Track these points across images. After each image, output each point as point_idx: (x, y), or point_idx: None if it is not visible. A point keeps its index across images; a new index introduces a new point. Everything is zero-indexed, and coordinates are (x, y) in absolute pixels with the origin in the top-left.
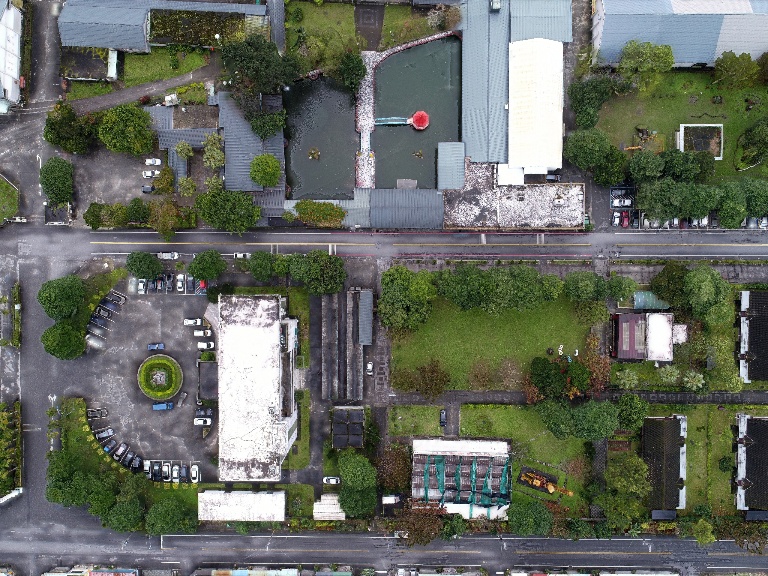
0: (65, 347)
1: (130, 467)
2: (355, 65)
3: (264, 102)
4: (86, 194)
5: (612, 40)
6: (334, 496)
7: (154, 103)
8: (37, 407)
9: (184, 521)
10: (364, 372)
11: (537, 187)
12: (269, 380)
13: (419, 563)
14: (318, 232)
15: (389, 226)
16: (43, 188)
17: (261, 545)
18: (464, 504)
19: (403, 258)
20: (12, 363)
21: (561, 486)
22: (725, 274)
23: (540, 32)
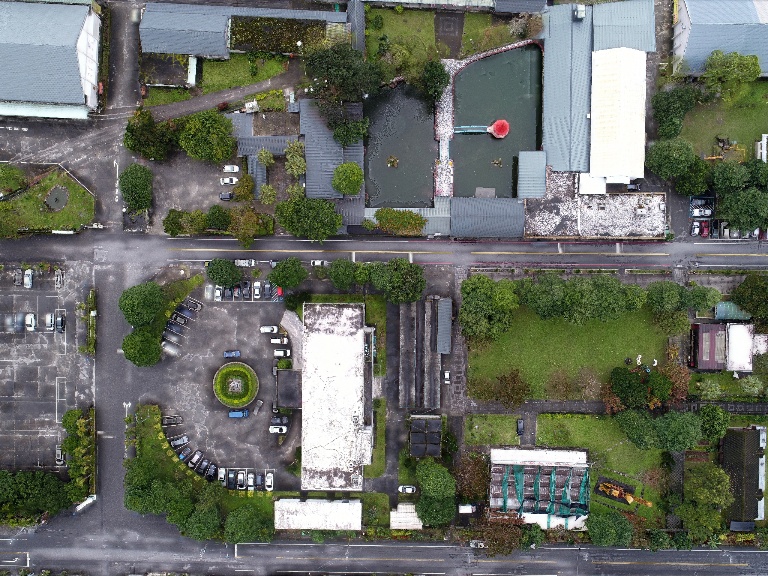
0: (145, 354)
1: (204, 475)
2: (439, 73)
3: (345, 110)
4: (163, 200)
5: (697, 50)
6: (411, 505)
7: (232, 110)
8: (112, 414)
9: (263, 530)
10: (441, 381)
11: (618, 196)
12: (352, 389)
13: (494, 573)
14: (396, 240)
15: (469, 235)
16: (123, 194)
17: (336, 554)
18: (542, 514)
19: (481, 267)
20: (87, 370)
21: (638, 496)
22: None
23: (623, 41)
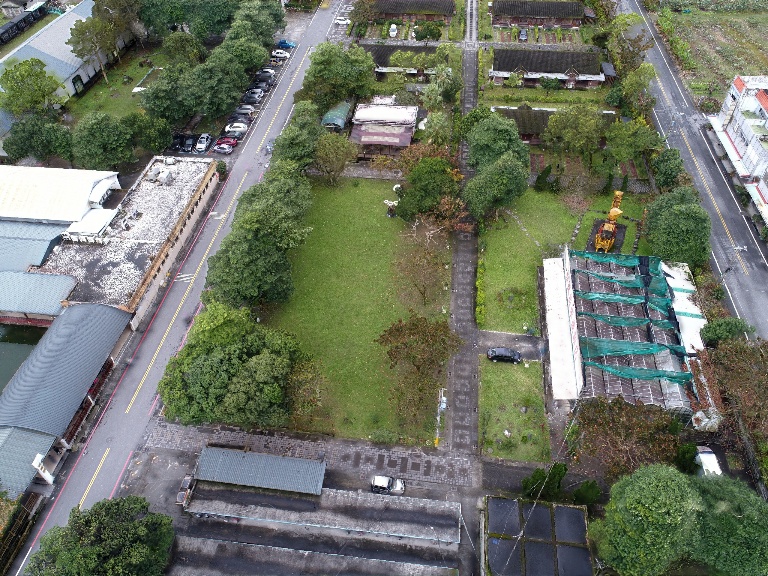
0: None
1: None
2: None
3: None
4: None
5: None
6: None
7: None
8: None
9: None
10: None
11: (131, 200)
12: None
13: None
14: None
15: (76, 400)
16: None
17: None
18: None
19: None
20: None
21: None
22: None
23: None
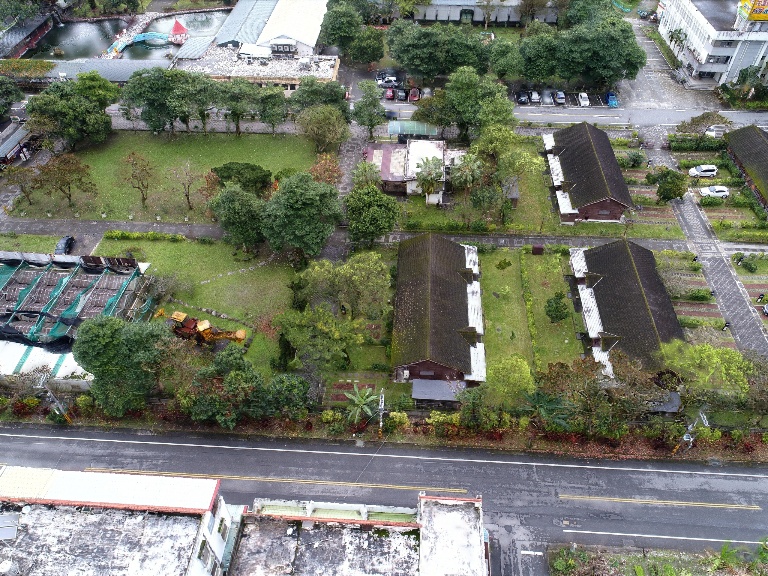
0: None
1: None
2: None
3: None
4: None
5: None
6: None
7: None
8: None
9: None
10: None
11: (285, 60)
12: None
13: None
14: None
15: None
16: None
17: None
18: (16, 345)
19: None
20: None
21: None
22: (522, 134)
23: None
